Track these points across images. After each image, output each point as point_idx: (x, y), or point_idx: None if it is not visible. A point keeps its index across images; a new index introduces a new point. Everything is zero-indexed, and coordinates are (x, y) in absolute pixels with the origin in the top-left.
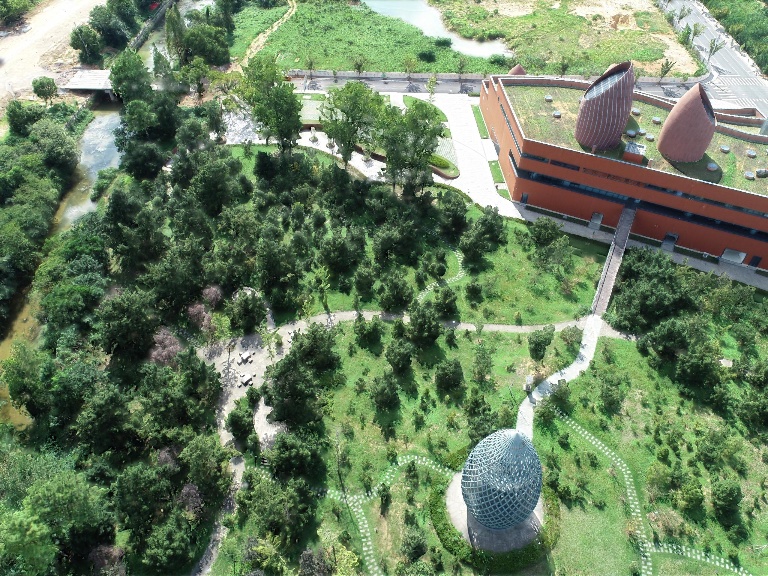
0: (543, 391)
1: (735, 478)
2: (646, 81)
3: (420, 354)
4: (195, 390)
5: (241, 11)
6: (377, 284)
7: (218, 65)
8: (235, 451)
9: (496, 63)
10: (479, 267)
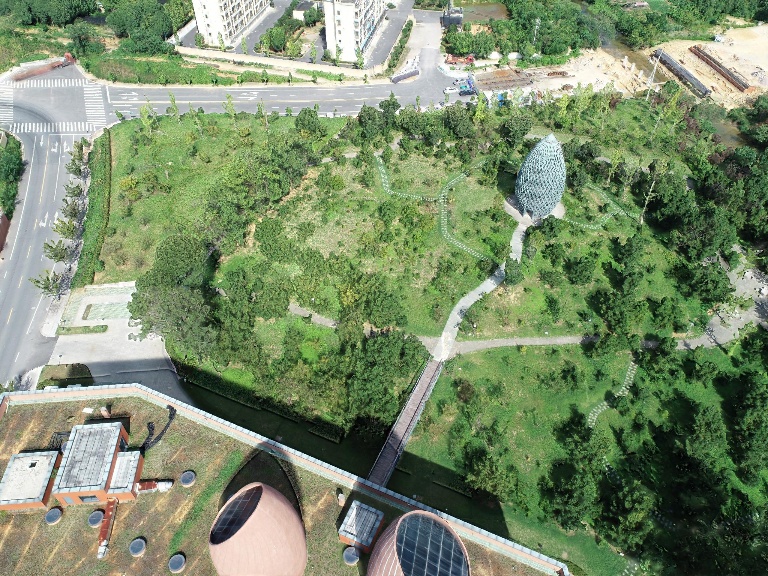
0: (501, 275)
1: (376, 224)
2: None
3: None
4: None
5: None
6: (687, 391)
7: None
8: None
9: None
10: (572, 430)
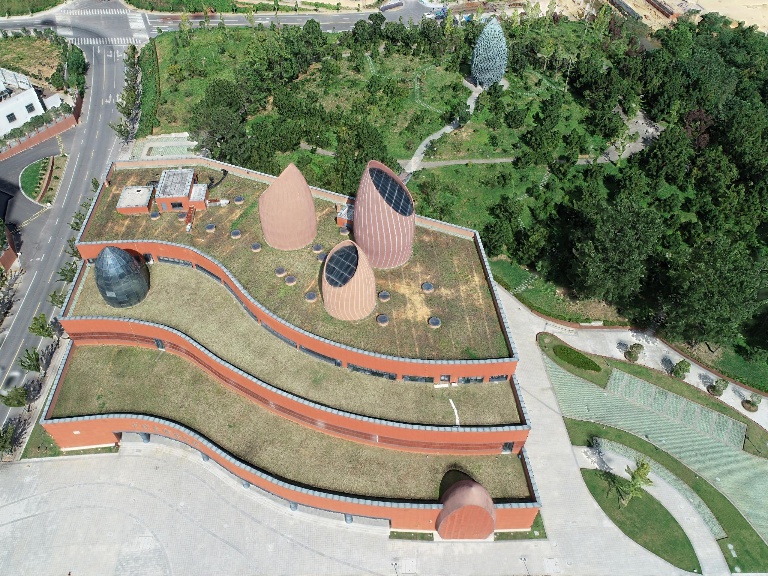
0: (457, 123)
1: None
2: None
3: None
4: None
5: None
6: None
7: None
8: None
9: None
10: None
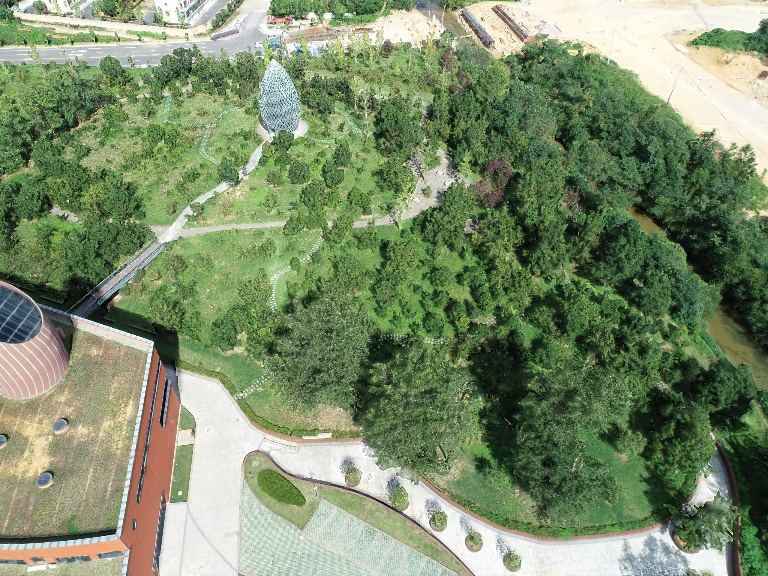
0: None
1: None
2: None
3: None
4: None
5: None
6: (358, 255)
7: None
8: (426, 126)
9: None
10: None
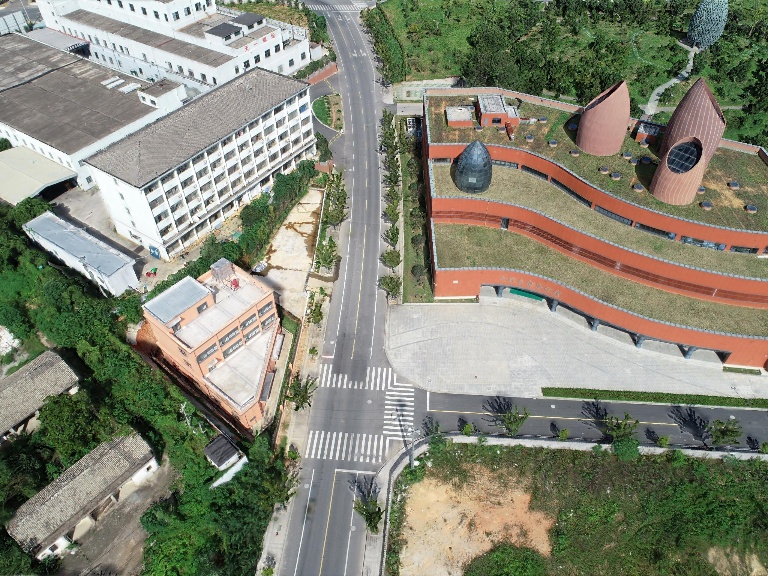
0: (682, 76)
1: None
2: (539, 445)
3: None
4: None
5: None
6: None
7: None
8: None
9: None
10: None
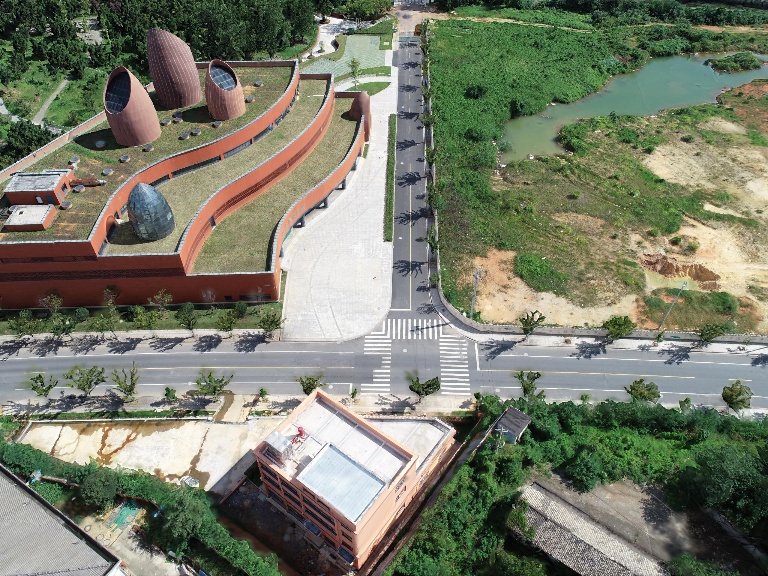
0: None
1: None
2: None
3: (50, 64)
4: (56, 6)
5: (575, 13)
6: None
7: (439, 8)
8: None
9: (466, 132)
10: None
